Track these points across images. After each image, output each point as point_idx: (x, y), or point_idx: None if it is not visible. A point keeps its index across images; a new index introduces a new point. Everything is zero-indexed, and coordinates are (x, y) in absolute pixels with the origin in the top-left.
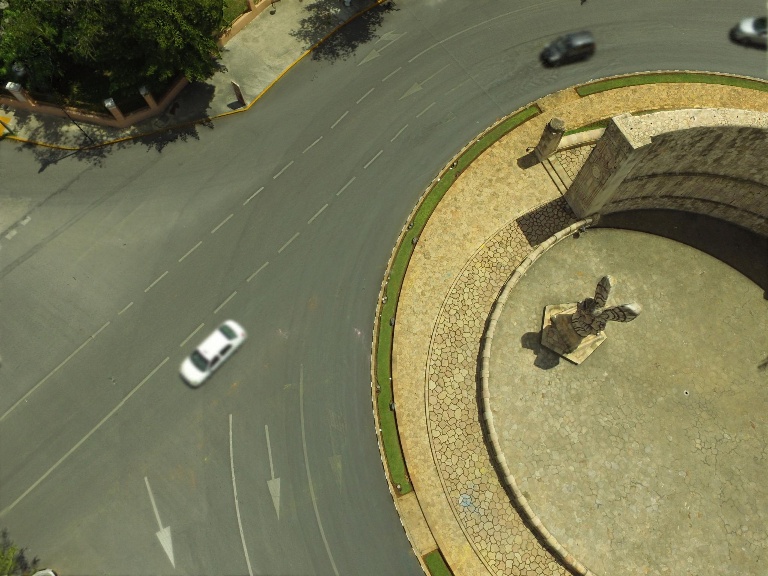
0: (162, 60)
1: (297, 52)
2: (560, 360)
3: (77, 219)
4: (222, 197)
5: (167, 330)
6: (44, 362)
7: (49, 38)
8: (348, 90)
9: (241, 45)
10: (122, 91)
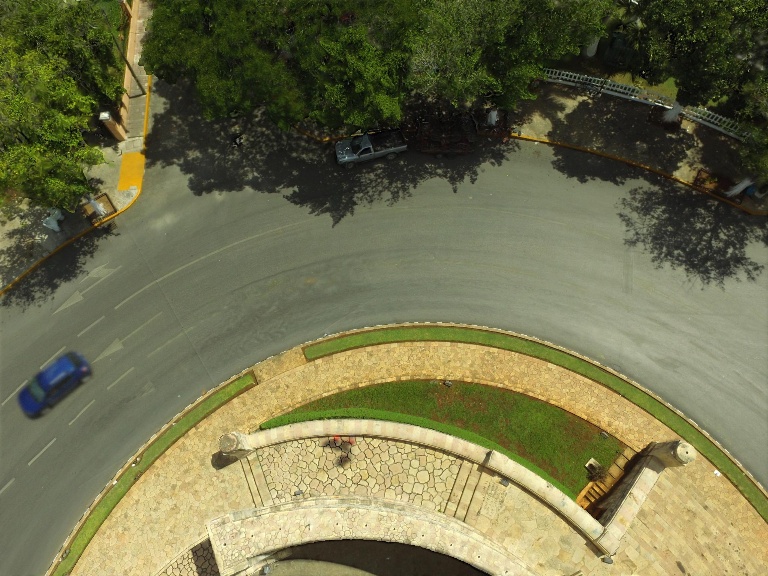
0: None
1: None
2: None
3: None
4: None
5: None
6: None
7: None
8: (34, 349)
9: None
10: None
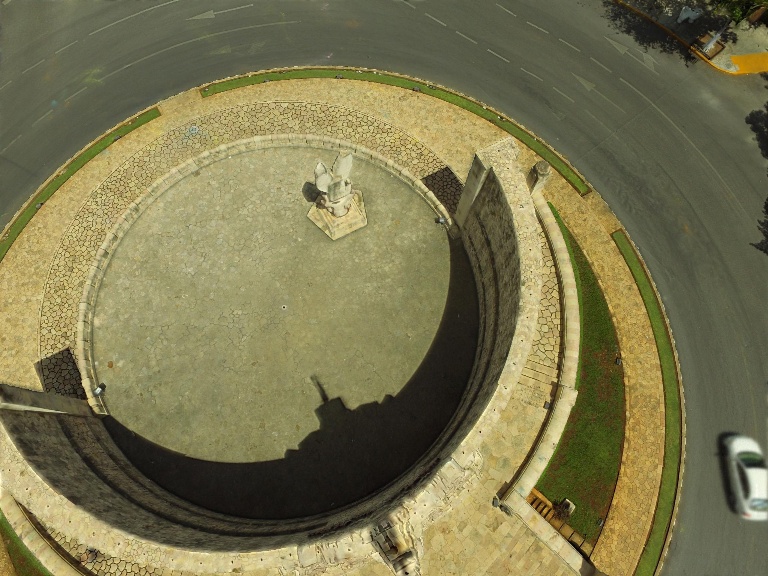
0: None
1: None
2: (311, 203)
3: None
4: None
5: None
6: None
7: None
8: (573, 31)
9: None
10: None
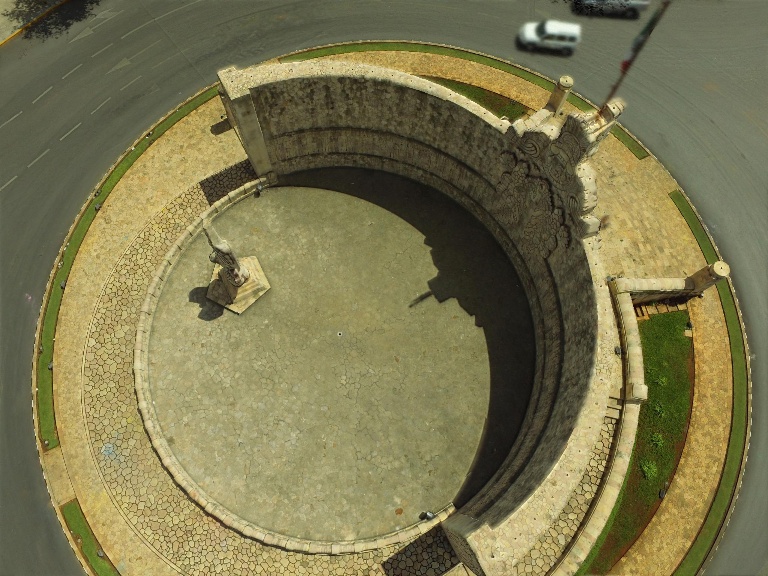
0: None
1: (7, 31)
2: (224, 311)
3: None
4: None
5: None
6: None
7: None
8: (55, 66)
9: None
10: None
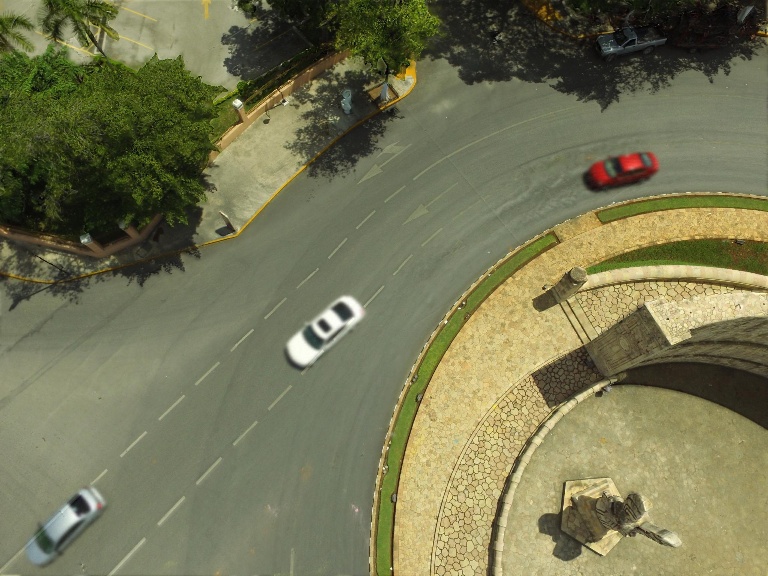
0: (139, 209)
1: (292, 168)
2: (582, 549)
3: (49, 367)
4: (208, 341)
5: (144, 504)
6: (7, 543)
7: (20, 170)
8: (347, 213)
9: (232, 160)
10: (99, 227)
